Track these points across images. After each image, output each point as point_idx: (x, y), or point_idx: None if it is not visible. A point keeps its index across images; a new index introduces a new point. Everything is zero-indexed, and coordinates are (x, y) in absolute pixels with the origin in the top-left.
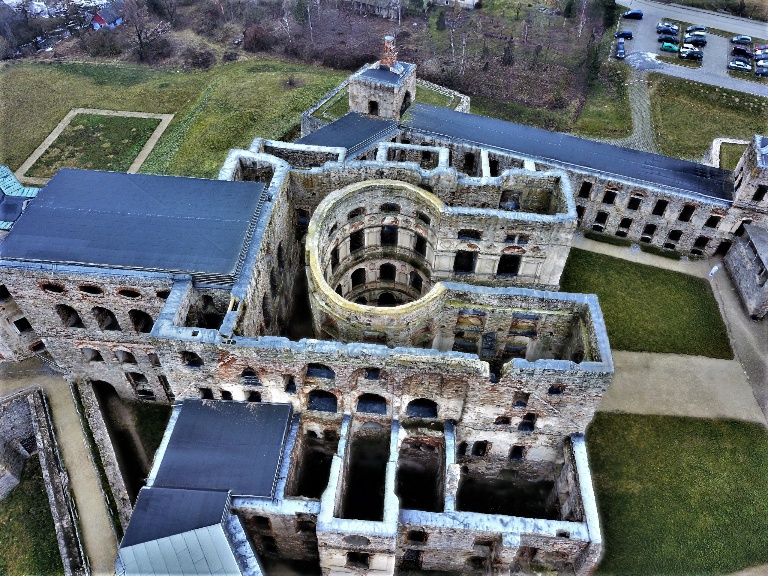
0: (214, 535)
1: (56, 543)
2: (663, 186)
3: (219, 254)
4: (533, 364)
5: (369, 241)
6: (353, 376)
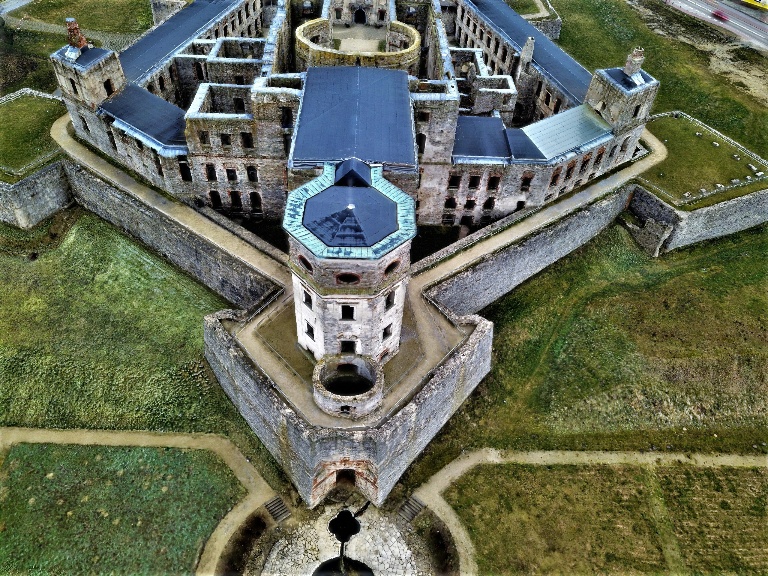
0: (528, 130)
1: (504, 309)
2: (235, 2)
3: (392, 76)
4: (439, 7)
5: None
6: None
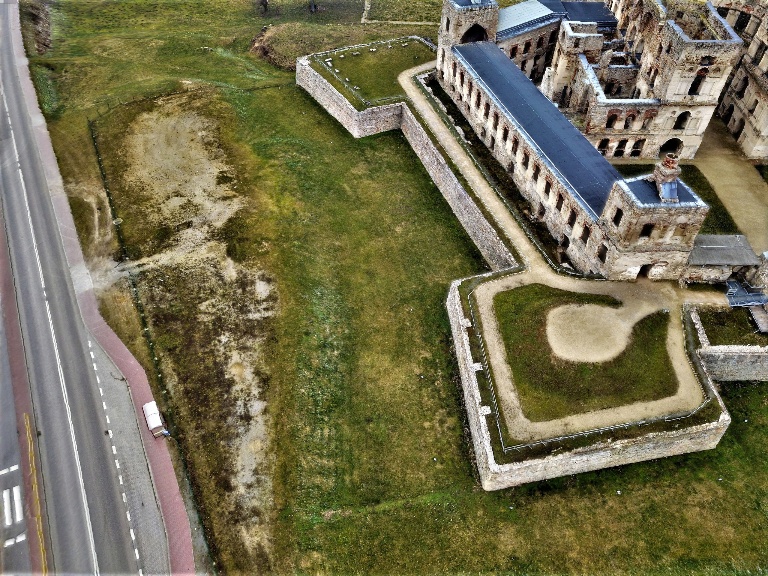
0: None
1: None
2: None
3: None
4: (673, 23)
5: (750, 29)
6: (638, 8)
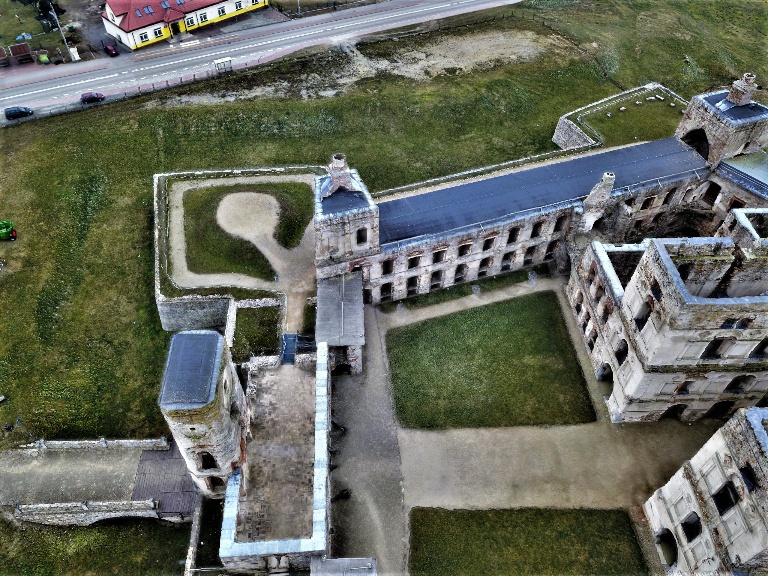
0: None
1: None
2: None
3: None
4: (718, 239)
5: None
6: None
